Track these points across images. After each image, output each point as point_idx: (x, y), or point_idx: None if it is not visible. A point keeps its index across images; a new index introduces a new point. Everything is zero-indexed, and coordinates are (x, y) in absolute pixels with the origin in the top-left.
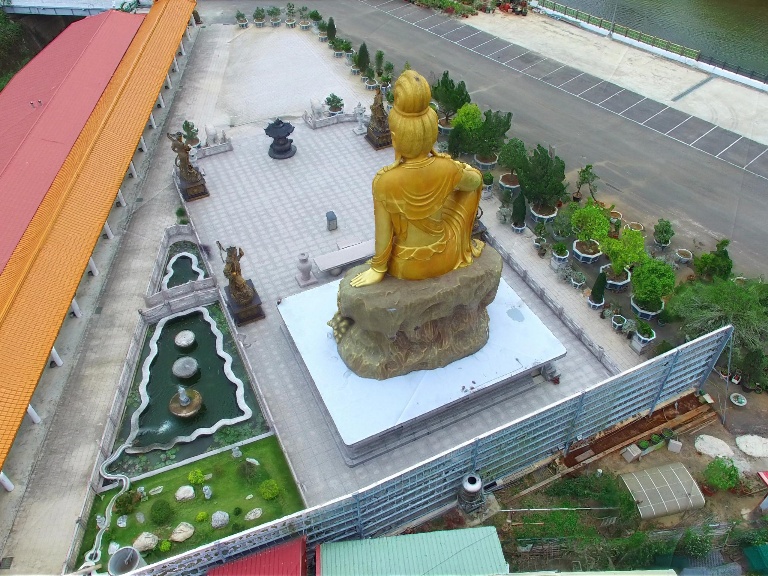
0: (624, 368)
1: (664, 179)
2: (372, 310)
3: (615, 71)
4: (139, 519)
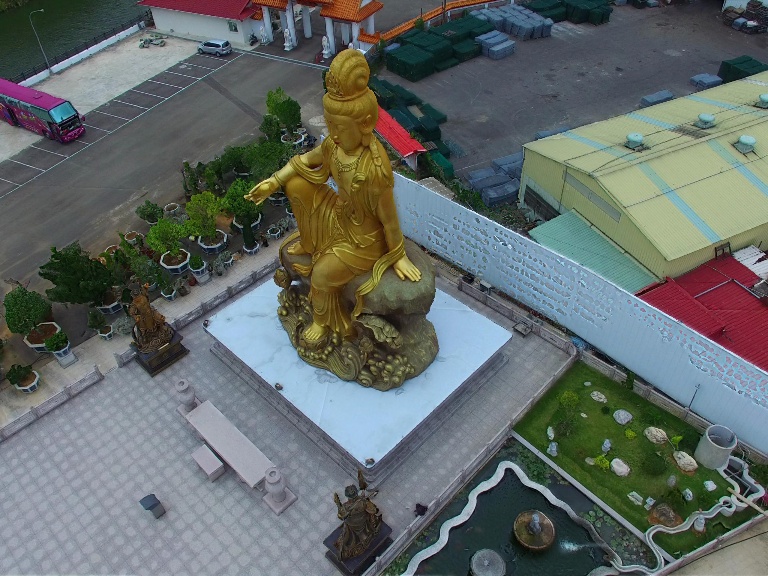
0: None
1: (36, 230)
2: None
3: None
4: (675, 481)
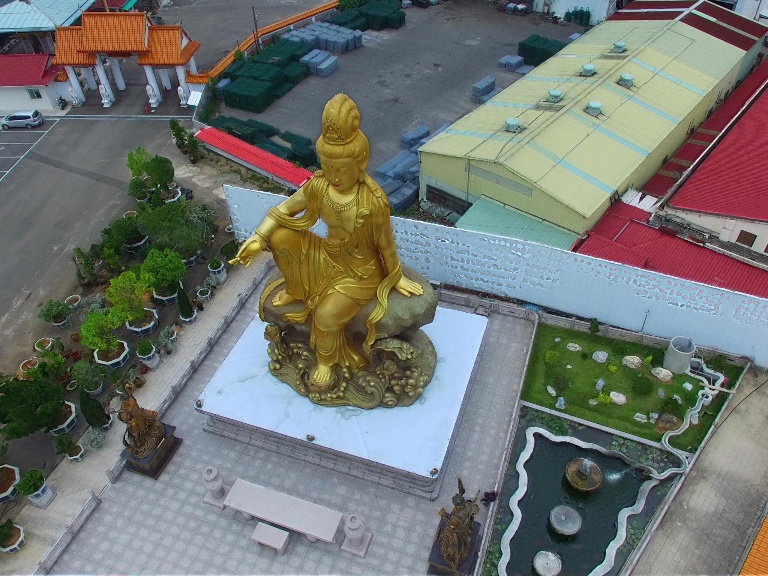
0: (250, 278)
1: None
2: None
3: None
4: (663, 392)
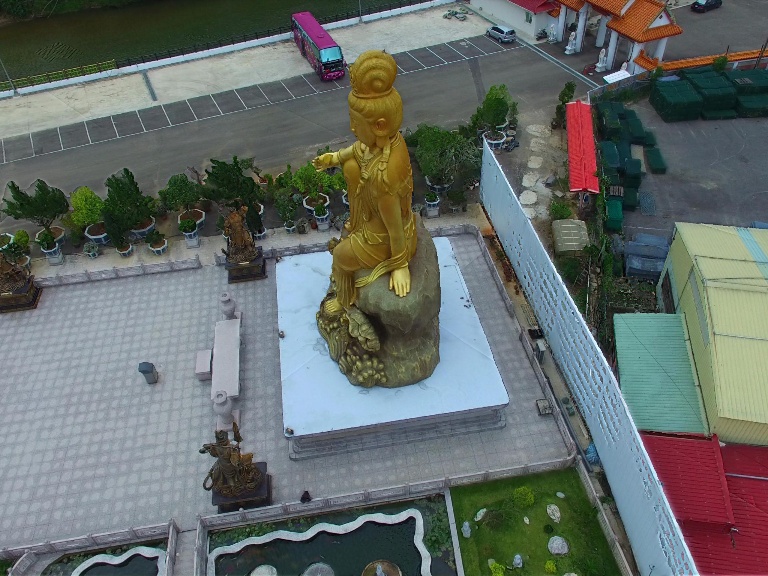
0: None
1: (254, 141)
2: (434, 294)
3: (77, 111)
4: None
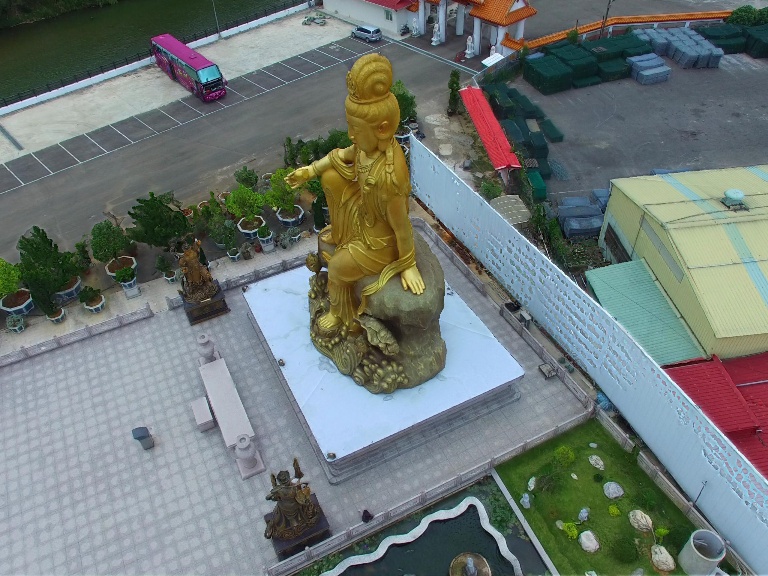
0: None
1: (154, 175)
2: None
3: None
4: (641, 574)
